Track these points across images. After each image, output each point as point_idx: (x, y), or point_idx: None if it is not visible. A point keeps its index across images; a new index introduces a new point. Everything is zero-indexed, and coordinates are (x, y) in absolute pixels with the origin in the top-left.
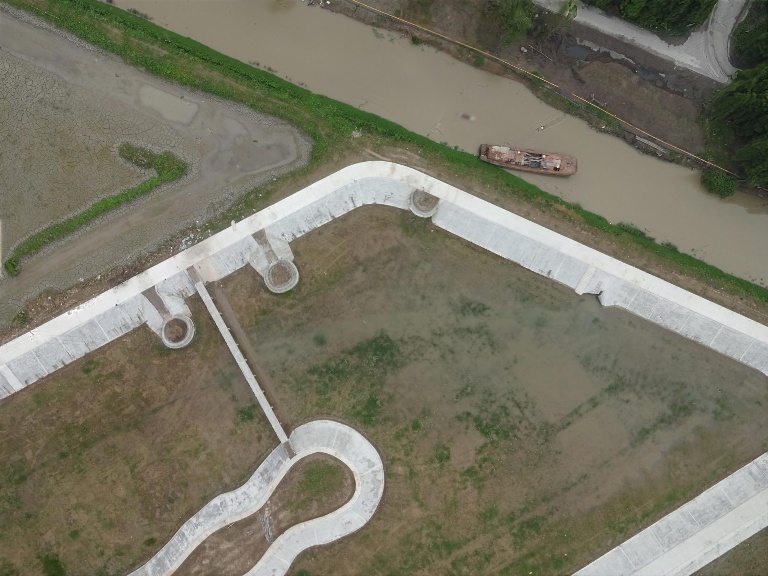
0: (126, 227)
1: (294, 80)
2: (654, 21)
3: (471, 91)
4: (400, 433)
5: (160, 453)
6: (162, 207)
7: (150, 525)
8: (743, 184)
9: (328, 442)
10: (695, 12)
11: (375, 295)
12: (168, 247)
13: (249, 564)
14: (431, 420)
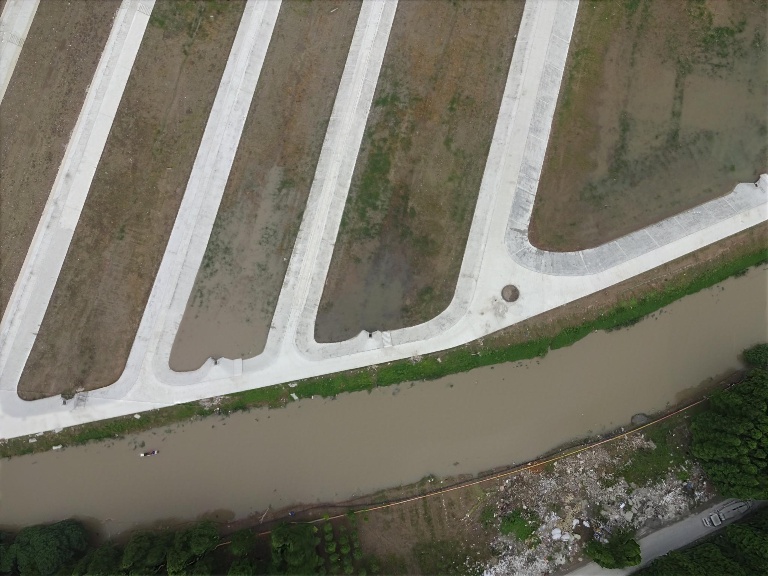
0: None
1: None
2: None
3: None
4: None
5: None
6: None
7: None
8: None
9: None
10: None
11: None
12: None
13: None
14: (757, 6)
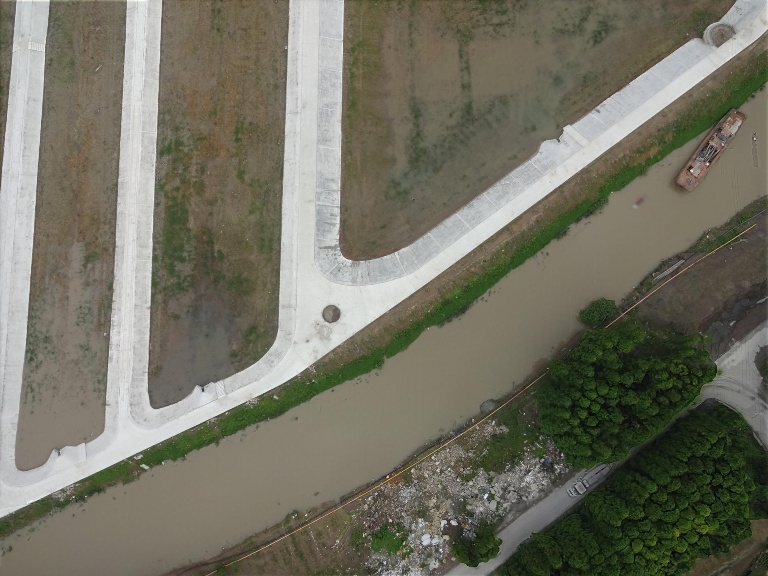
0: None
1: None
2: None
3: None
4: None
5: None
6: None
7: None
8: None
9: None
10: None
11: None
12: None
13: None
14: None
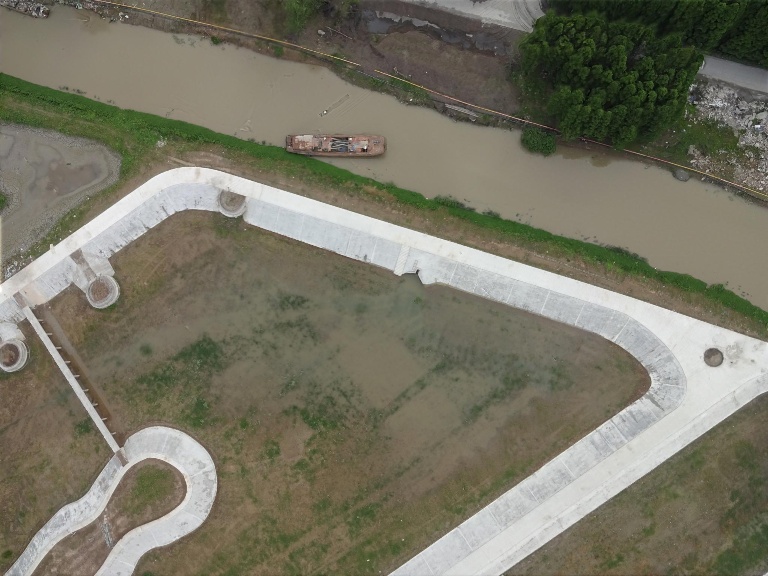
0: None
1: (102, 99)
2: None
3: (279, 82)
4: (229, 432)
5: (9, 471)
6: None
7: (6, 539)
8: (561, 139)
9: (158, 448)
10: None
11: (195, 300)
12: None
13: (93, 569)
14: (259, 417)
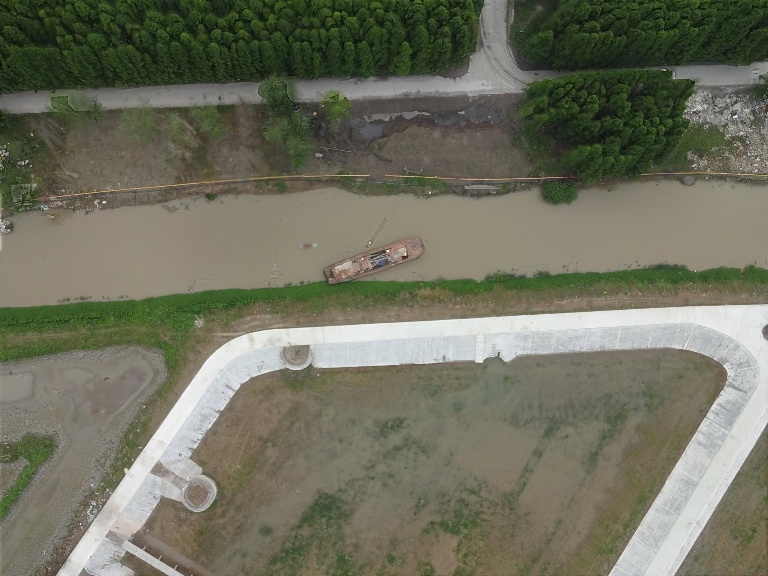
0: (26, 526)
1: (112, 297)
2: (428, 70)
3: (289, 215)
4: (380, 573)
5: None
6: (50, 489)
7: None
8: None
9: None
10: (462, 50)
11: (295, 462)
12: (77, 525)
13: None
14: (402, 547)
